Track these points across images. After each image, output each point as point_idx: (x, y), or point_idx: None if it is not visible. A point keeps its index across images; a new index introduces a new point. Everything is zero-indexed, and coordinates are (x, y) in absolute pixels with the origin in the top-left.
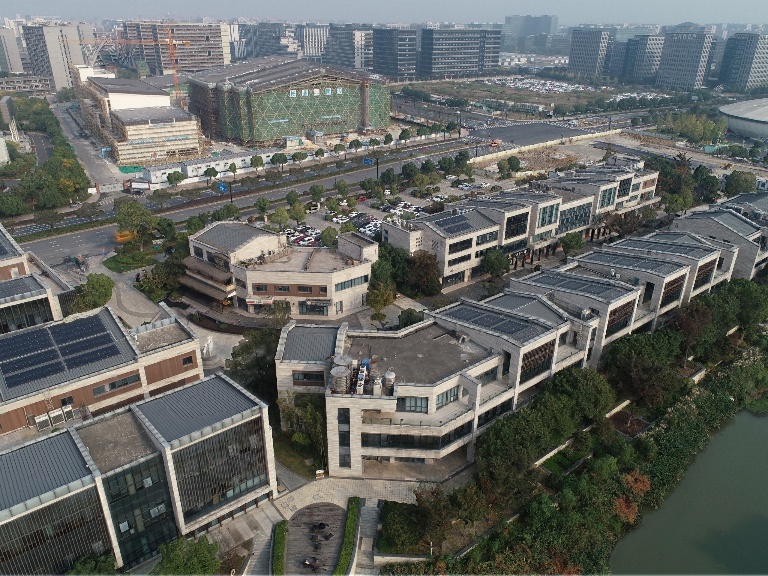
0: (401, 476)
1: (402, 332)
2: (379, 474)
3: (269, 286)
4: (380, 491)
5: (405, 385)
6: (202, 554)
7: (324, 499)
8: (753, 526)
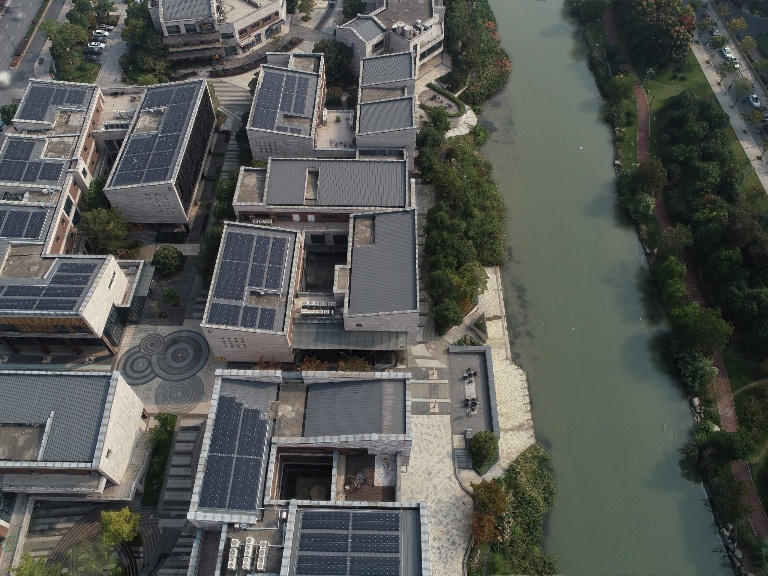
0: (429, 69)
1: (385, 5)
2: (422, 74)
3: (247, 28)
4: (430, 78)
5: (426, 22)
6: (443, 109)
7: (419, 91)
8: (524, 21)
